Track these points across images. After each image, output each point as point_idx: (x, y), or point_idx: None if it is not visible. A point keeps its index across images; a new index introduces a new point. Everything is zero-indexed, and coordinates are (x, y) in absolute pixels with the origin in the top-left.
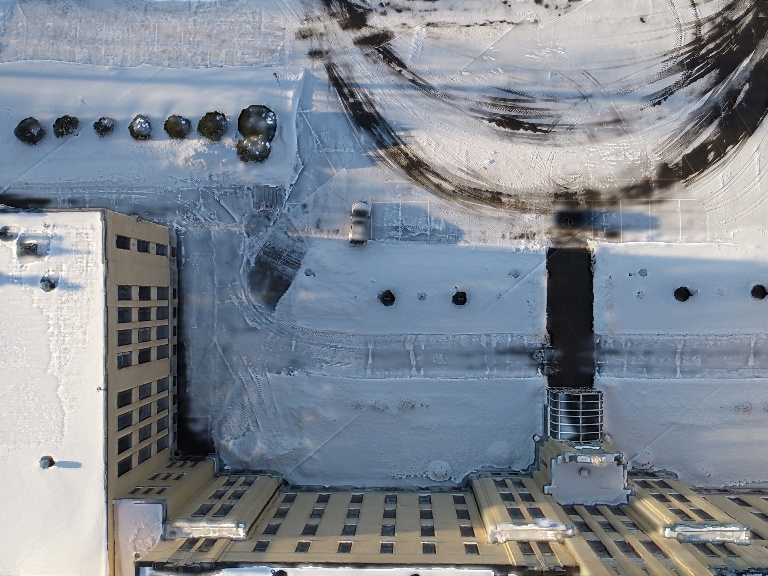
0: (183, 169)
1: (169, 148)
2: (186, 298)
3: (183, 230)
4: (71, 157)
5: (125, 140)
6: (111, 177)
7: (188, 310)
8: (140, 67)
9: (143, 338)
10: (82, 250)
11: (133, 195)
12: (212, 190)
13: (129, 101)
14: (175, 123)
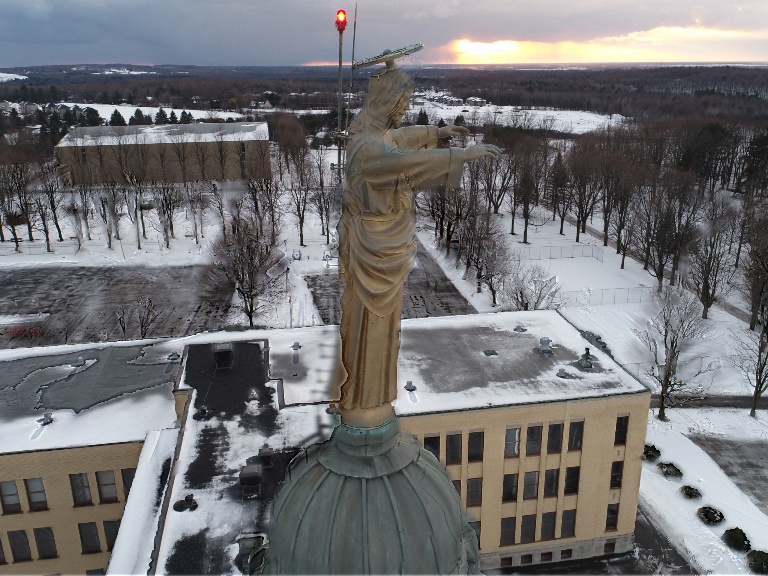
0: (699, 547)
1: (710, 536)
2: (566, 568)
3: (636, 556)
4: (646, 476)
5: (690, 508)
6: (649, 499)
7: (554, 571)
8: (766, 515)
9: (527, 486)
10: (606, 385)
11: (644, 515)
12: (696, 575)
13: (728, 509)
14: (740, 532)
